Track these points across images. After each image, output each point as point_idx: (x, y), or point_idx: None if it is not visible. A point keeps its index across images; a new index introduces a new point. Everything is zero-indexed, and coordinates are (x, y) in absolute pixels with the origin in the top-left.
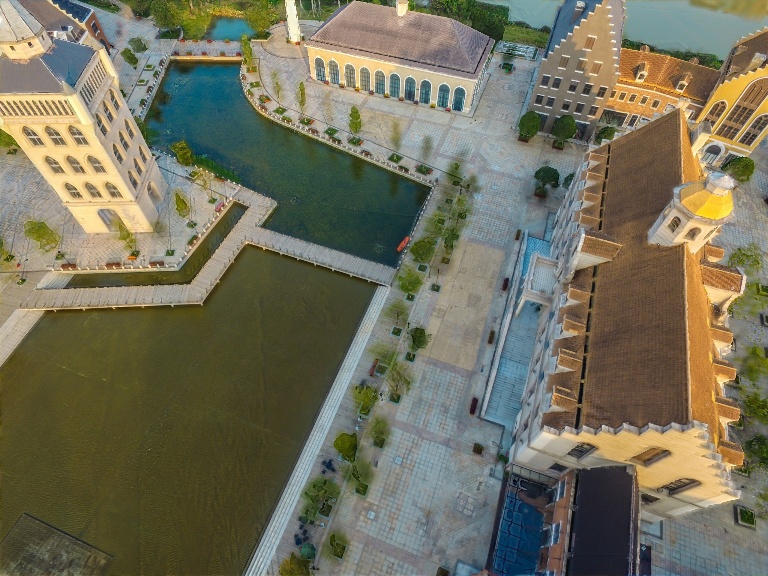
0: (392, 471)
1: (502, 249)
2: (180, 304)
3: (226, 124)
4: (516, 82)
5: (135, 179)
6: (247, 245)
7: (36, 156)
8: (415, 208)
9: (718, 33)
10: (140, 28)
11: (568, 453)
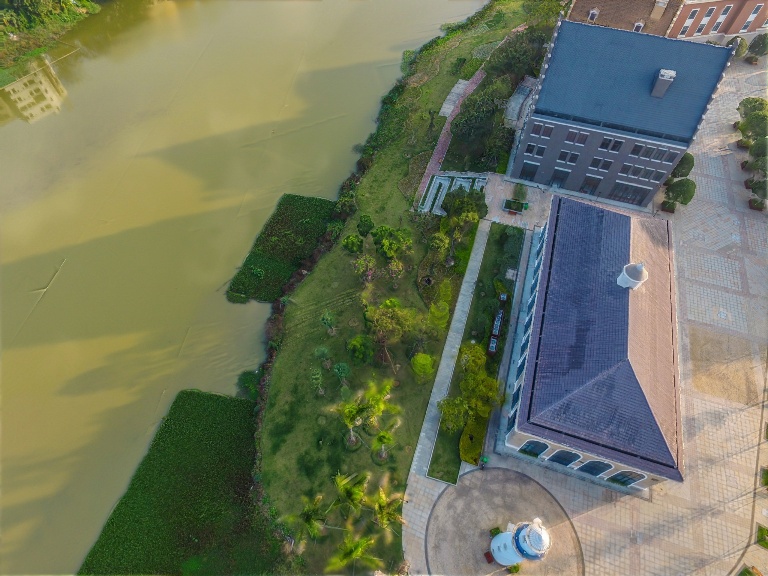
0: None
1: None
2: None
3: None
4: (546, 202)
5: None
6: None
7: None
8: None
9: (358, 38)
10: None
11: None
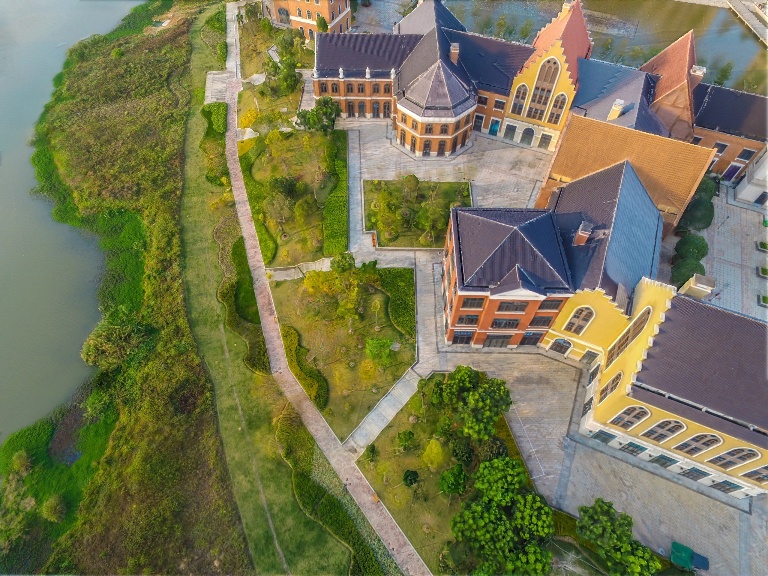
0: None
1: None
2: (763, 41)
3: None
4: None
5: None
6: None
7: None
8: None
9: None
10: None
11: None
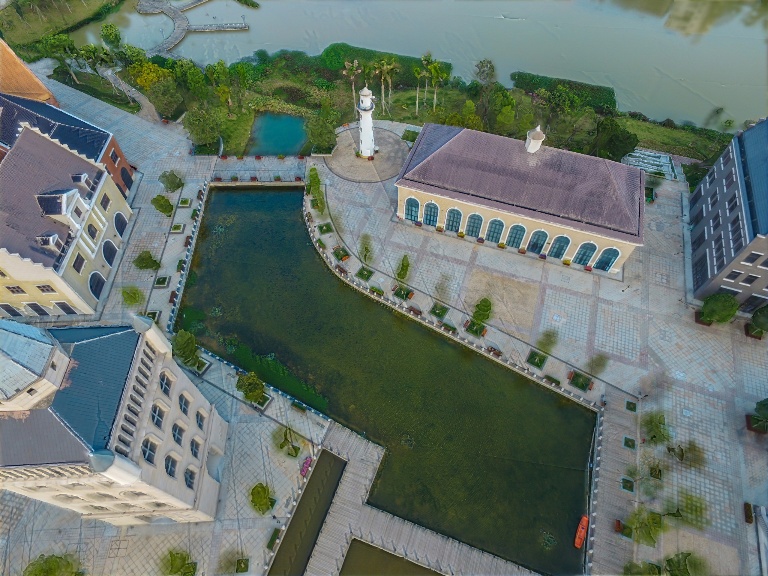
0: None
1: (732, 543)
2: None
3: (294, 295)
4: (664, 217)
5: (192, 470)
6: (353, 541)
7: (41, 495)
8: (581, 453)
9: None
10: (168, 137)
11: None
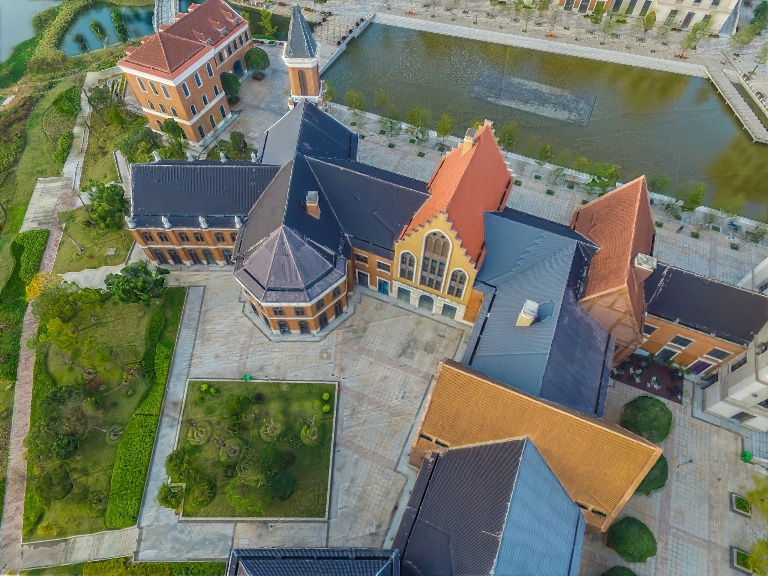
0: (677, 241)
1: None
2: (748, 130)
3: None
4: None
5: None
6: None
7: None
8: None
9: None
10: None
11: (763, 286)
